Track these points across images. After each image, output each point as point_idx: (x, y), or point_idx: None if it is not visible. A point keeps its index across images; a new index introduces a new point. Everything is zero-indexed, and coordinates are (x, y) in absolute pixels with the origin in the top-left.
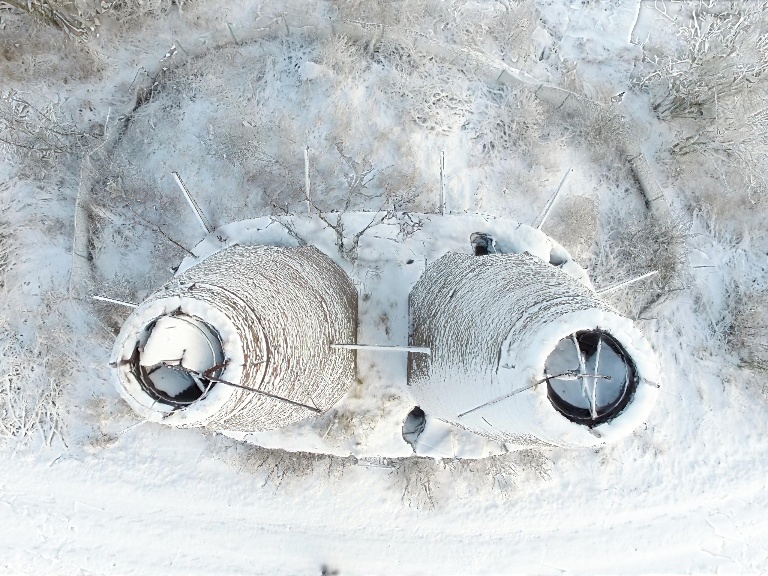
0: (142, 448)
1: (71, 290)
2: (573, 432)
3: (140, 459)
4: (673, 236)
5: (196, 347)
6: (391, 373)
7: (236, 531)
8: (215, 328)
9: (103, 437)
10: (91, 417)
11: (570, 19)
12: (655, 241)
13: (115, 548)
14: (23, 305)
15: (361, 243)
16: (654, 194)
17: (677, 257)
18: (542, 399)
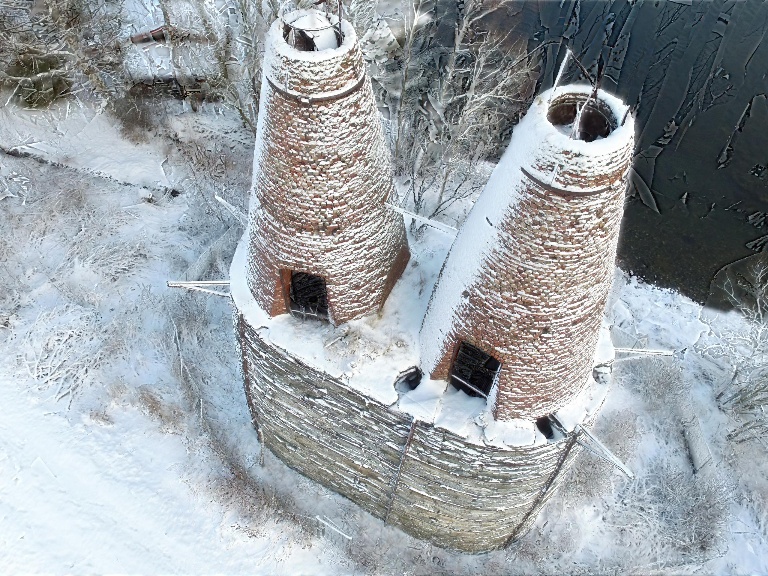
0: (128, 440)
1: (162, 302)
2: (558, 135)
3: (119, 448)
4: (716, 500)
5: (326, 40)
6: (409, 323)
7: (155, 565)
8: (344, 33)
9: (104, 415)
10: (106, 395)
11: (652, 311)
12: (695, 499)
13: (36, 521)
14: (119, 300)
15: (428, 234)
16: (702, 460)
17: (717, 521)
18: (542, 112)
